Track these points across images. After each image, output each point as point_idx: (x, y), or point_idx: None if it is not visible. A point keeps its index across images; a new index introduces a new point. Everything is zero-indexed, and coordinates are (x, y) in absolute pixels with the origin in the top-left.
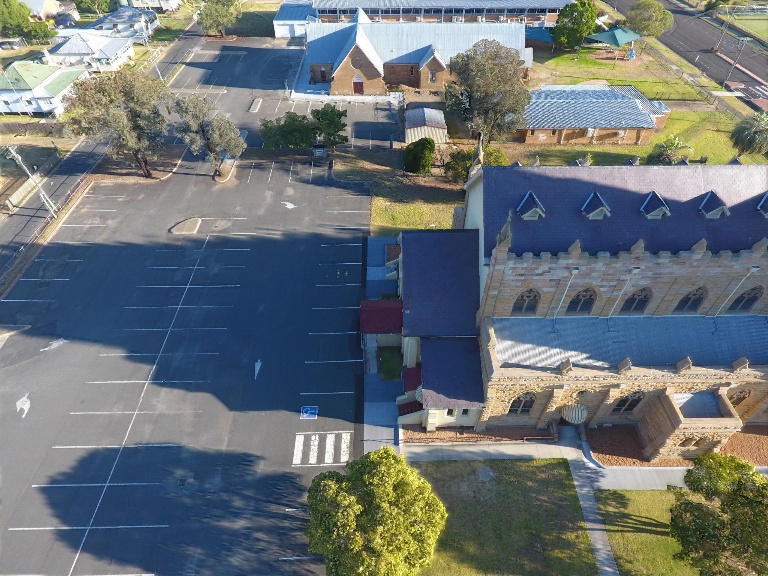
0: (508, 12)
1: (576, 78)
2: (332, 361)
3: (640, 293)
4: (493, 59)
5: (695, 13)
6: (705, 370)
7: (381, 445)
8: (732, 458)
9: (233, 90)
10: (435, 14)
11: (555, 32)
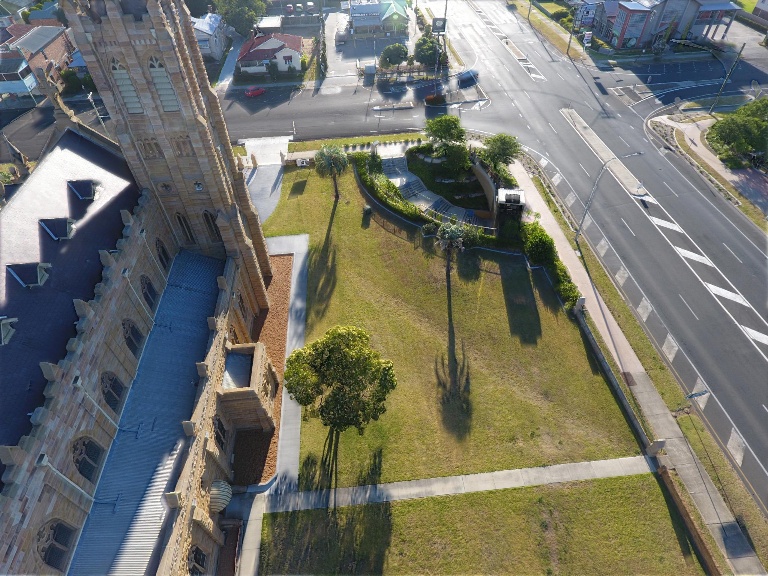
0: None
1: None
2: None
3: (104, 384)
4: None
5: None
6: (210, 353)
7: None
8: (289, 362)
9: None
10: None
11: None
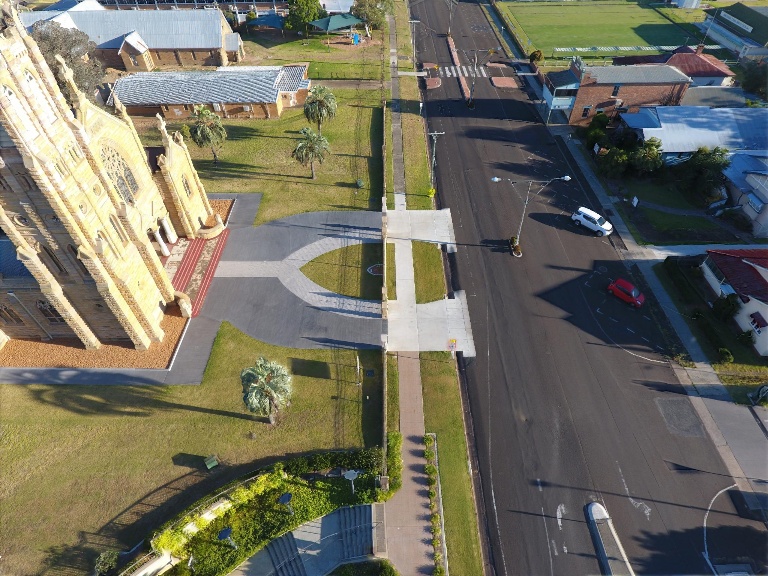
0: (257, 1)
1: (283, 61)
2: None
3: None
4: (47, 38)
5: (480, 1)
6: None
7: None
8: None
9: None
10: (188, 3)
11: (284, 19)
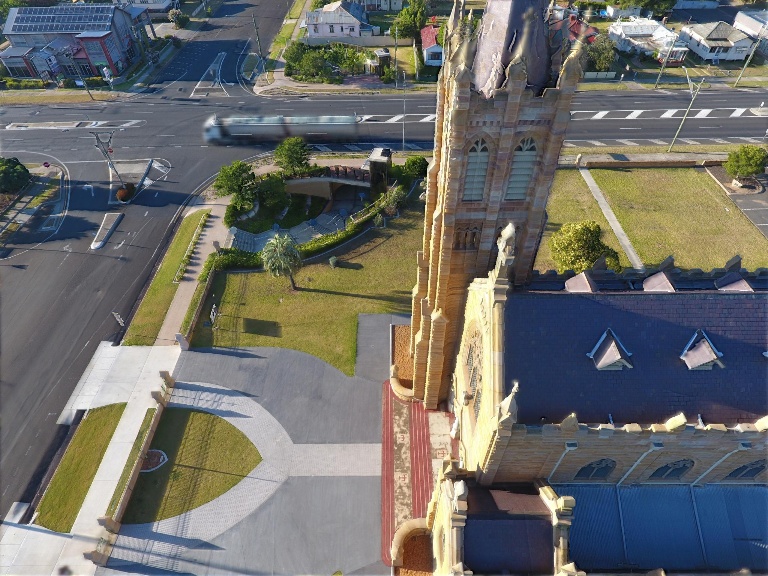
0: None
1: None
2: None
3: None
4: None
5: None
6: None
7: None
8: None
9: None
10: None
11: None
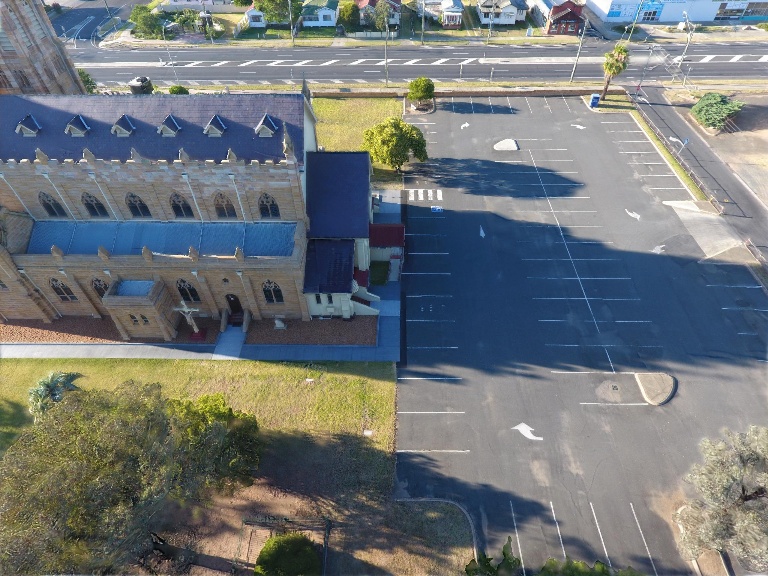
0: None
1: None
2: (426, 235)
3: None
4: None
5: None
6: None
7: (390, 195)
8: None
9: None
10: None
11: None
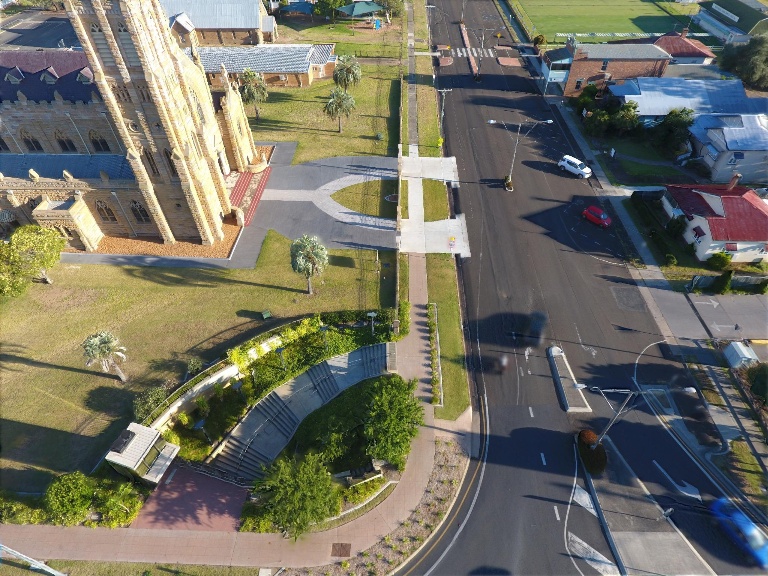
0: None
1: (313, 41)
2: None
3: (26, 135)
4: None
5: None
6: (50, 180)
7: None
8: None
9: (25, 48)
10: None
11: None
